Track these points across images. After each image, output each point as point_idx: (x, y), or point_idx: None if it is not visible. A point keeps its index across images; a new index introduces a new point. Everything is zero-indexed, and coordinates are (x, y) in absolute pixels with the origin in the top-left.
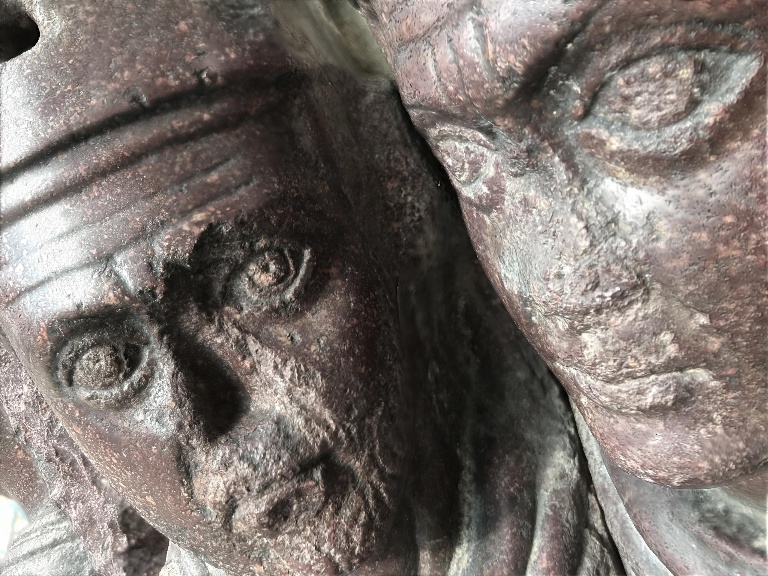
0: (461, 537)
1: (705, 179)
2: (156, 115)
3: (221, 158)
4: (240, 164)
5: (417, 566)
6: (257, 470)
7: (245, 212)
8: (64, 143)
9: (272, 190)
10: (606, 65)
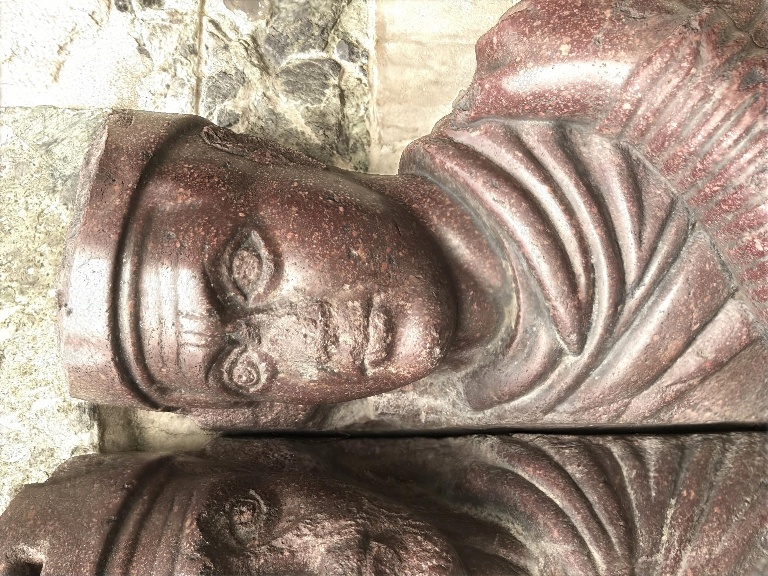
0: (505, 527)
1: (288, 264)
2: (125, 519)
3: (170, 502)
4: (181, 495)
5: (509, 562)
6: (347, 574)
7: (204, 501)
8: (99, 572)
9: (205, 487)
10: (228, 278)
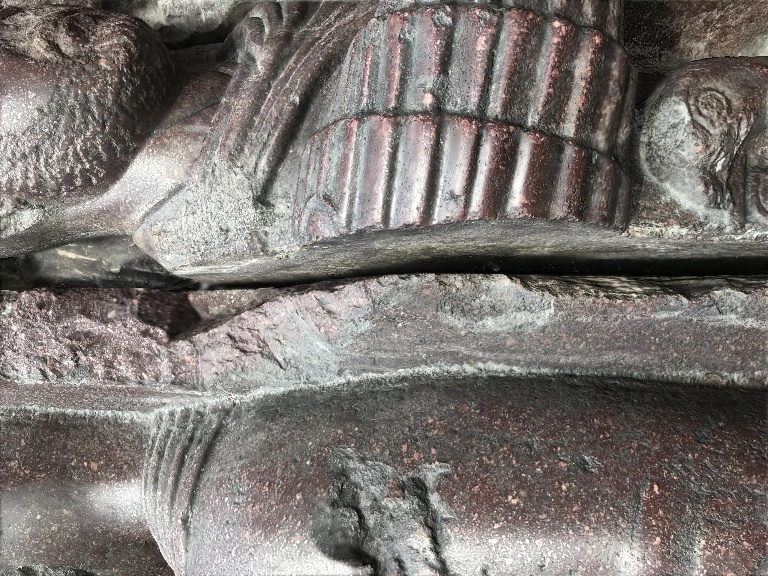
0: None
1: None
2: None
3: None
4: None
5: None
6: None
7: None
8: None
9: None
10: None
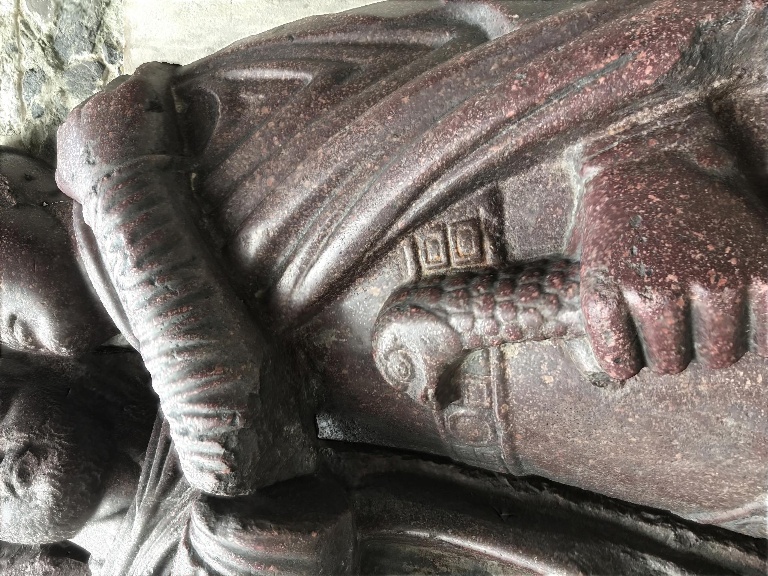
0: None
1: None
2: None
3: None
4: None
5: (141, 470)
6: (5, 466)
7: None
8: None
9: None
10: None
